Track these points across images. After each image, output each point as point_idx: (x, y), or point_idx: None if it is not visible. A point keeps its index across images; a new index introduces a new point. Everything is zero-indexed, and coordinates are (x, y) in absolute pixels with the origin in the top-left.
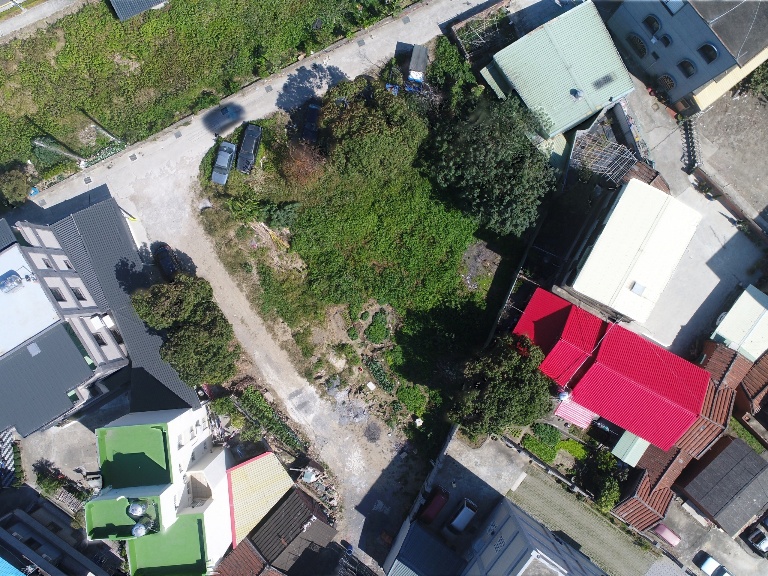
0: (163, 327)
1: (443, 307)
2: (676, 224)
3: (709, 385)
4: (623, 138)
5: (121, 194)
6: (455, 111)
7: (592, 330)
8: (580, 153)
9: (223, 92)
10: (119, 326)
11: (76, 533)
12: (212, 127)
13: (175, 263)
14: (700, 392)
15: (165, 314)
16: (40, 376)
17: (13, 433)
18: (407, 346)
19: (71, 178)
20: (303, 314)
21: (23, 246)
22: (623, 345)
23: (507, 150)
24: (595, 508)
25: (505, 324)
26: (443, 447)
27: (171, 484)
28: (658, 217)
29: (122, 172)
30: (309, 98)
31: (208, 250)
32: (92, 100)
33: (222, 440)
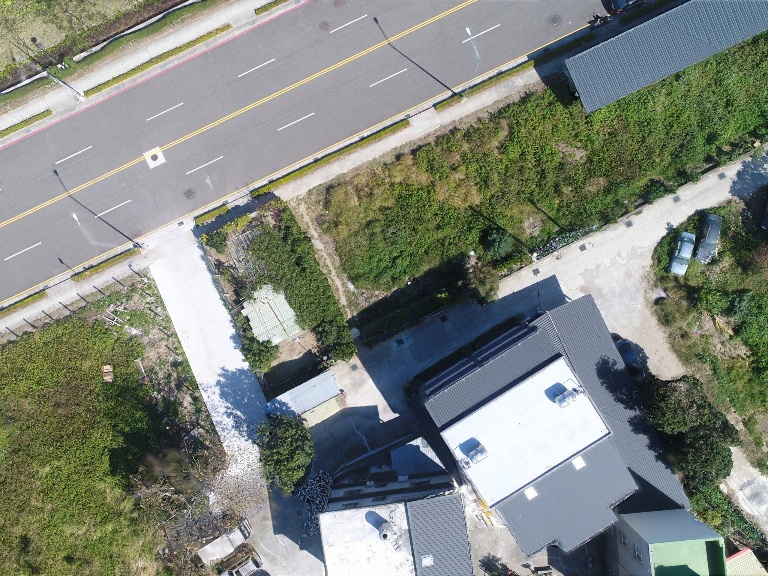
0: (677, 431)
1: None
2: None
3: None
4: None
5: (571, 285)
6: None
7: None
8: None
9: (674, 180)
10: None
11: None
12: (664, 216)
13: None
14: None
15: None
16: (584, 490)
17: None
18: None
19: (522, 270)
20: (750, 402)
21: None
22: None
23: None
24: None
25: None
26: None
27: None
28: None
29: (571, 263)
30: (763, 185)
31: (660, 340)
32: (539, 190)
33: None
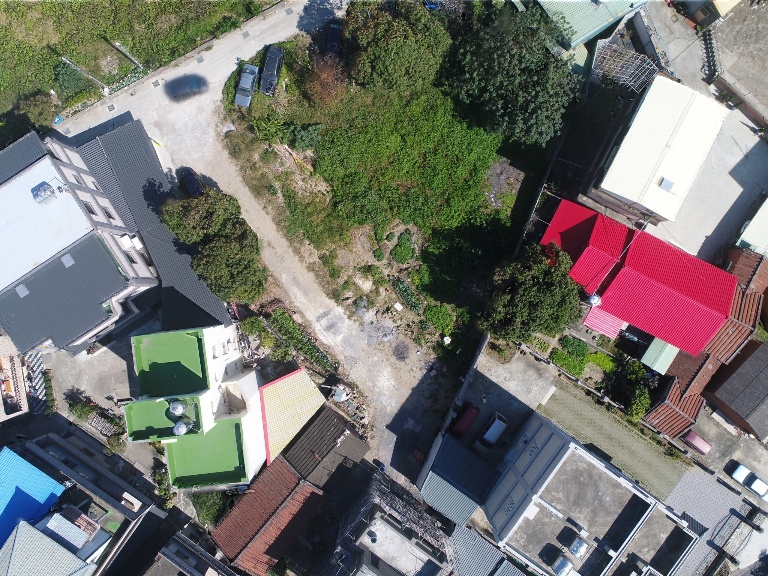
0: (194, 241)
1: (468, 225)
2: (702, 119)
3: (736, 289)
4: (643, 50)
5: (145, 120)
6: (477, 24)
7: (619, 237)
8: (601, 64)
9: (244, 16)
10: (148, 246)
11: (109, 459)
12: (234, 51)
13: (201, 186)
14: (728, 295)
15: (196, 227)
16: (74, 287)
17: (43, 362)
18: (433, 265)
19: (95, 105)
20: (329, 236)
21: (54, 159)
22: (650, 251)
23: (530, 57)
24: (625, 419)
25: (531, 239)
26: (472, 363)
27: (208, 390)
28: (684, 113)
29: (145, 99)
30: (330, 19)
31: (233, 174)
32: (113, 28)
33: (252, 361)
